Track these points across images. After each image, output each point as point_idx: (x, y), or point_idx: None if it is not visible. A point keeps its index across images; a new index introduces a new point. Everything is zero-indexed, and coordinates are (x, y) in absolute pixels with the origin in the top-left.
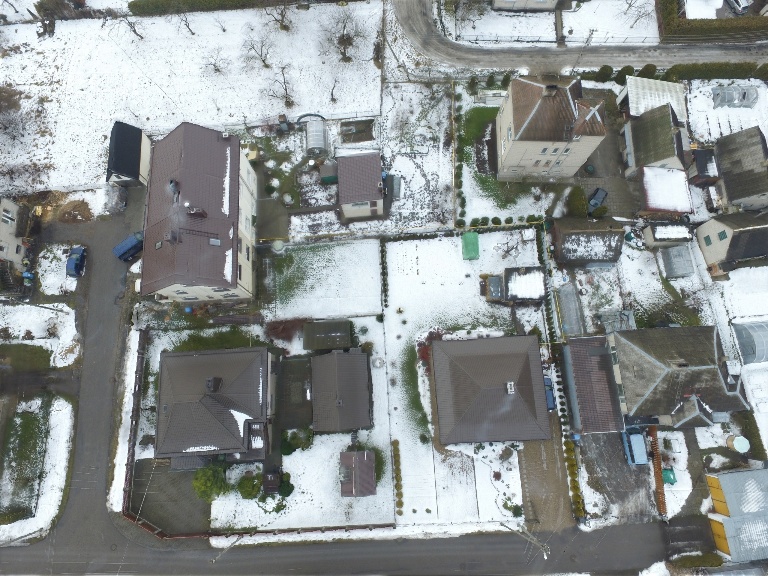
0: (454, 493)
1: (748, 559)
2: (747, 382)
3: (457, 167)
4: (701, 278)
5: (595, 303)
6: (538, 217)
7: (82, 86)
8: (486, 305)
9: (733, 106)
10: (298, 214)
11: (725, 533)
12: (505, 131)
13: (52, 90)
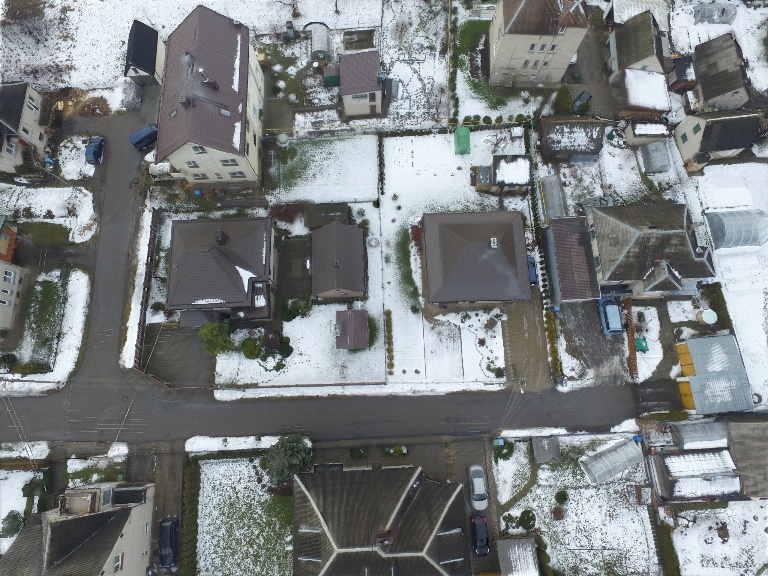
0: (441, 357)
1: (711, 412)
2: (717, 265)
3: (452, 72)
4: (677, 173)
5: (577, 194)
6: (526, 116)
7: None
8: (476, 194)
9: (713, 22)
10: (302, 112)
11: (691, 389)
12: (497, 33)
13: (74, 0)
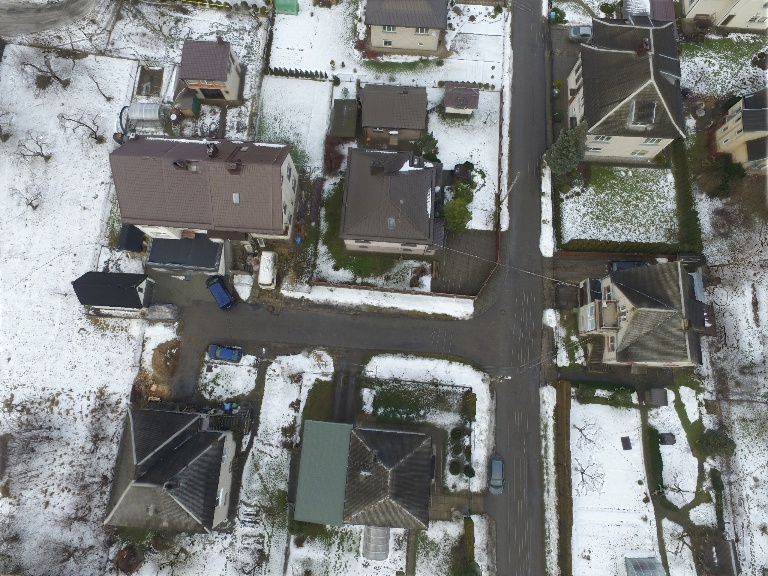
0: (482, 49)
1: None
2: None
3: (210, 6)
4: None
5: None
6: None
7: (4, 359)
8: (339, 6)
9: None
10: None
11: None
12: None
13: None
